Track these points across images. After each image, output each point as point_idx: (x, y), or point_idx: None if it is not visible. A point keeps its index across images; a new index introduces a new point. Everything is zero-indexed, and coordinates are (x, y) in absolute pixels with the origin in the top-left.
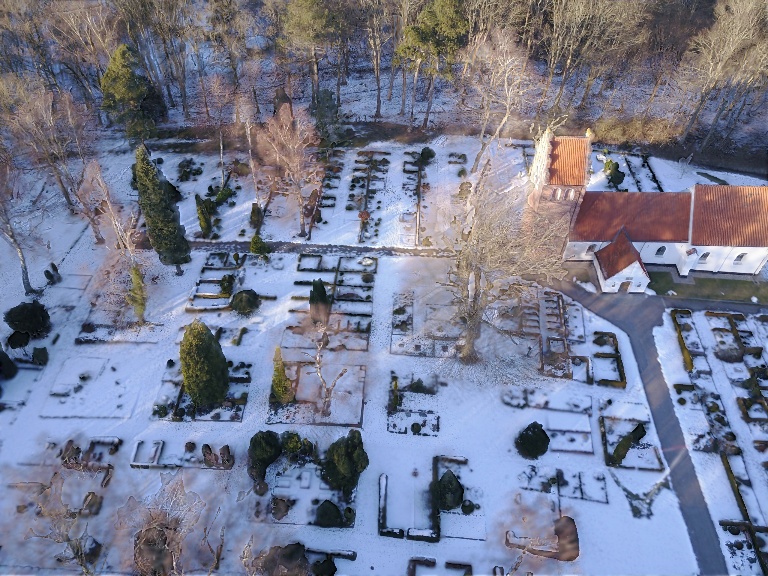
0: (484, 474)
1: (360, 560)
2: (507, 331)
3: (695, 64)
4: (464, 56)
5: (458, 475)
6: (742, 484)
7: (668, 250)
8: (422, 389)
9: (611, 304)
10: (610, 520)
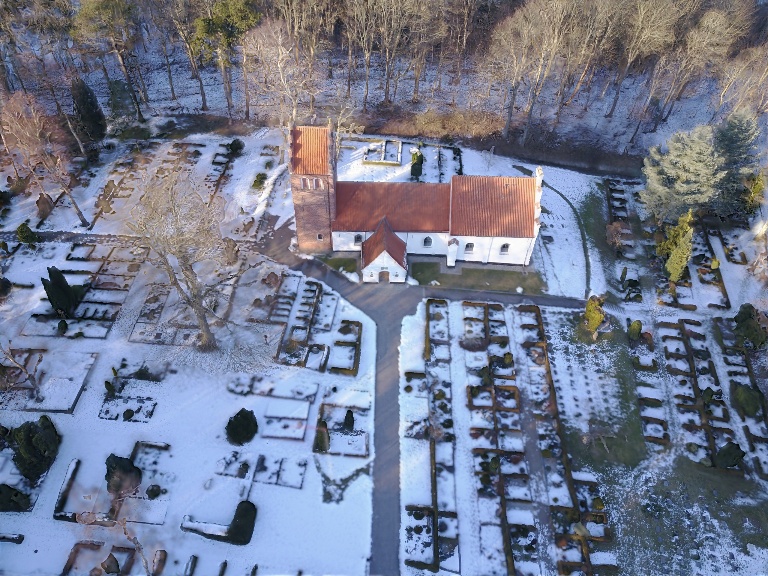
0: (183, 460)
1: (26, 543)
2: (253, 320)
3: (499, 57)
4: (248, 47)
5: (155, 461)
6: (445, 470)
7: (434, 240)
8: (146, 376)
9: (369, 294)
10: (298, 505)
